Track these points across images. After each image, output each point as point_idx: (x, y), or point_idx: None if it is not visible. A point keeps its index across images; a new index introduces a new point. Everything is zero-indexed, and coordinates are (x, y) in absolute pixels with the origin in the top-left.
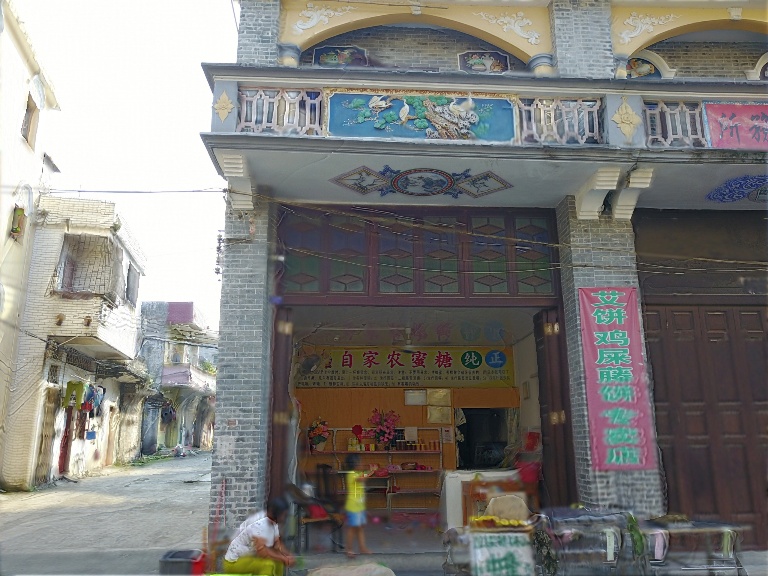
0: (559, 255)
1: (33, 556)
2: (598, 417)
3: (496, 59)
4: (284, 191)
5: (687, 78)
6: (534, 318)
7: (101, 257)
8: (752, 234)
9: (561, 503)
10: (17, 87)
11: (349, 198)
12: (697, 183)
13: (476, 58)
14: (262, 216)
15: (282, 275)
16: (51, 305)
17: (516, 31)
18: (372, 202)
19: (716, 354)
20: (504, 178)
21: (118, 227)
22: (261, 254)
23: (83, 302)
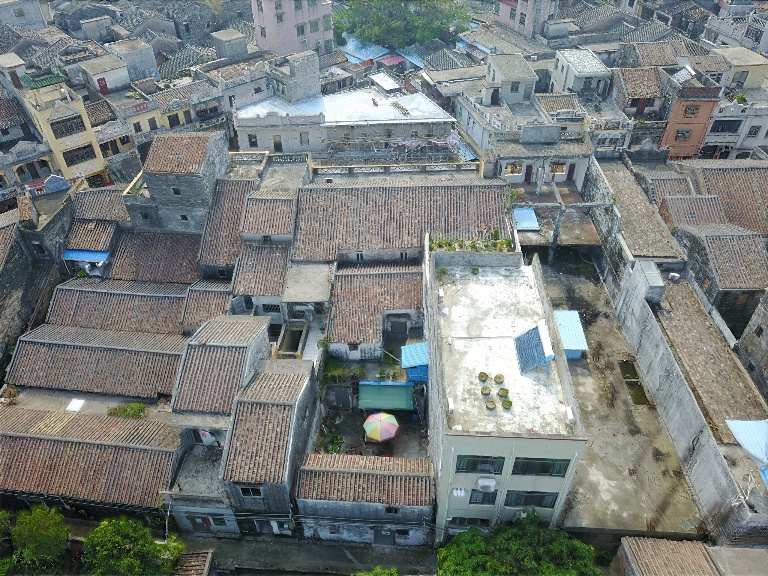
0: None
1: None
2: None
3: None
4: None
5: (25, 163)
6: None
7: None
8: None
9: None
10: None
11: None
12: None
13: None
14: None
15: None
16: None
17: None
18: None
19: None
20: None
21: None
22: None
23: None
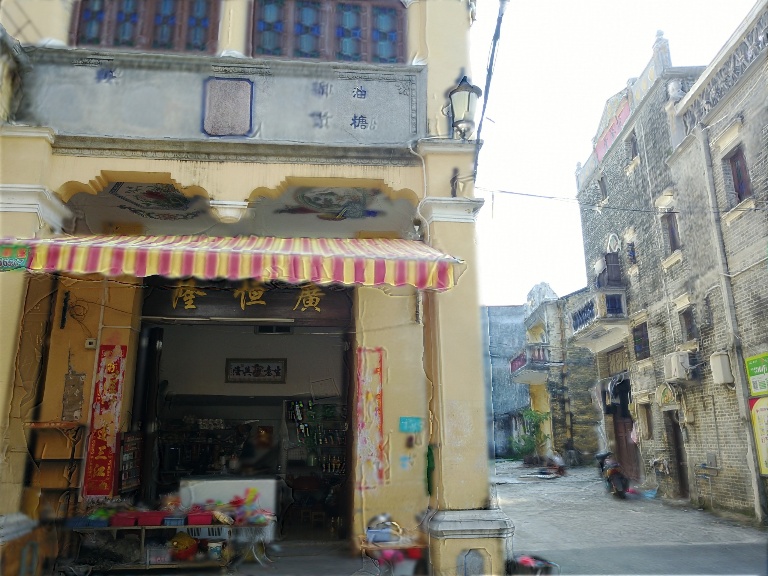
0: None
1: (647, 548)
2: None
3: None
4: None
5: None
6: None
7: None
8: None
9: None
10: None
11: None
12: None
13: None
14: None
15: None
16: None
17: None
18: None
19: None
20: None
21: None
22: None
23: None
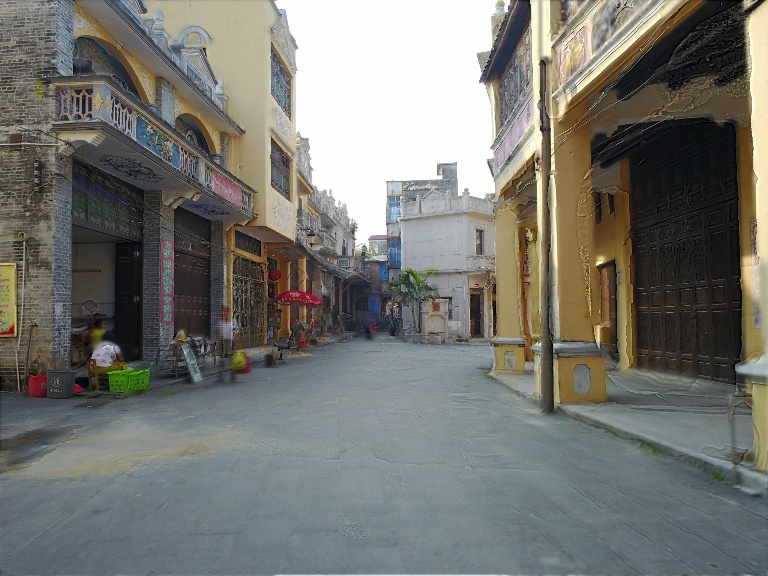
0: (143, 216)
1: None
2: (162, 300)
3: (124, 86)
4: (90, 154)
5: None
6: (118, 245)
7: None
8: (187, 221)
9: (134, 340)
10: None
11: (91, 160)
12: (199, 201)
13: (118, 81)
14: (70, 163)
15: None
16: None
17: (147, 84)
18: (96, 165)
19: (175, 274)
20: (163, 180)
21: None
22: (70, 189)
23: None
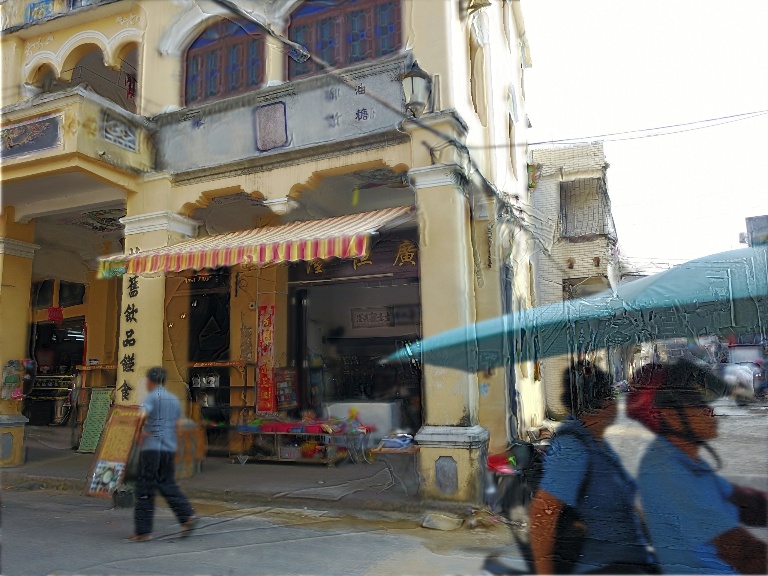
0: None
1: (728, 478)
2: None
3: None
4: None
5: None
6: None
7: (598, 198)
8: None
9: None
10: (517, 52)
11: None
12: None
13: None
14: None
15: None
16: (560, 251)
17: None
18: None
19: None
20: None
21: (608, 166)
22: None
23: (589, 244)
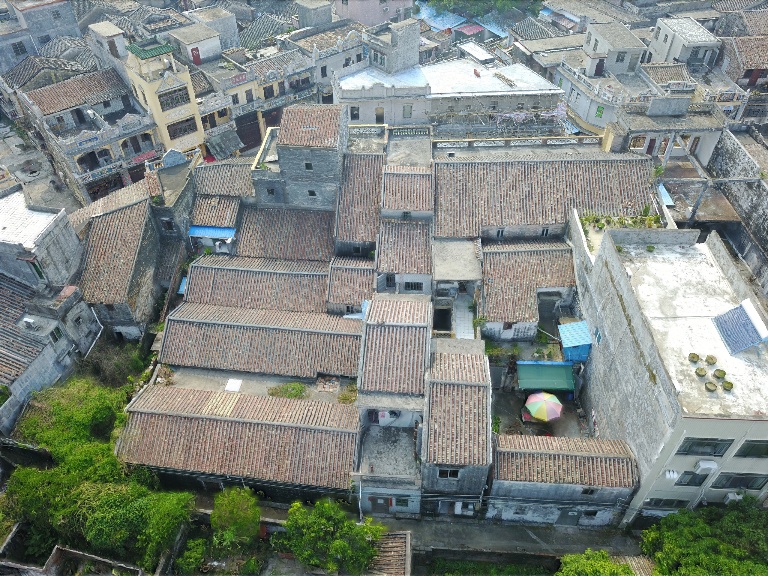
0: None
1: None
2: None
3: None
4: None
5: None
6: None
7: None
8: None
9: None
10: None
11: None
12: None
13: None
14: None
15: (86, 187)
16: None
17: None
18: None
19: None
20: None
21: None
22: None
23: None
